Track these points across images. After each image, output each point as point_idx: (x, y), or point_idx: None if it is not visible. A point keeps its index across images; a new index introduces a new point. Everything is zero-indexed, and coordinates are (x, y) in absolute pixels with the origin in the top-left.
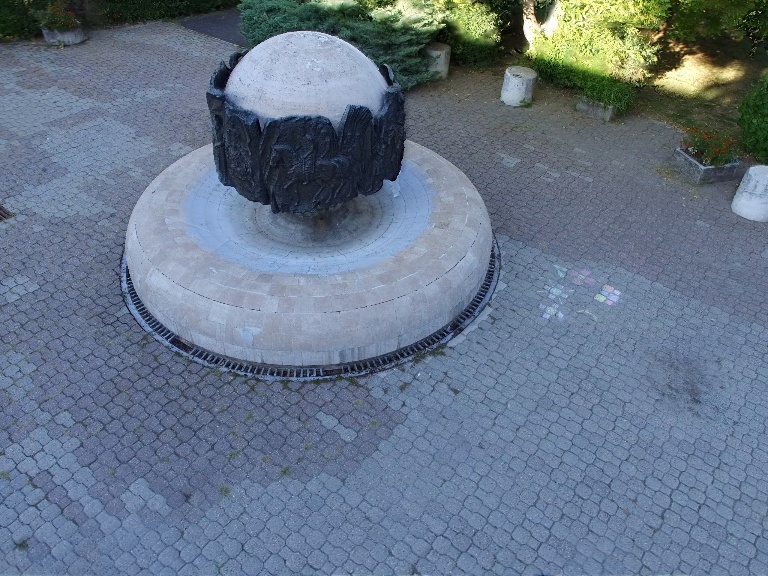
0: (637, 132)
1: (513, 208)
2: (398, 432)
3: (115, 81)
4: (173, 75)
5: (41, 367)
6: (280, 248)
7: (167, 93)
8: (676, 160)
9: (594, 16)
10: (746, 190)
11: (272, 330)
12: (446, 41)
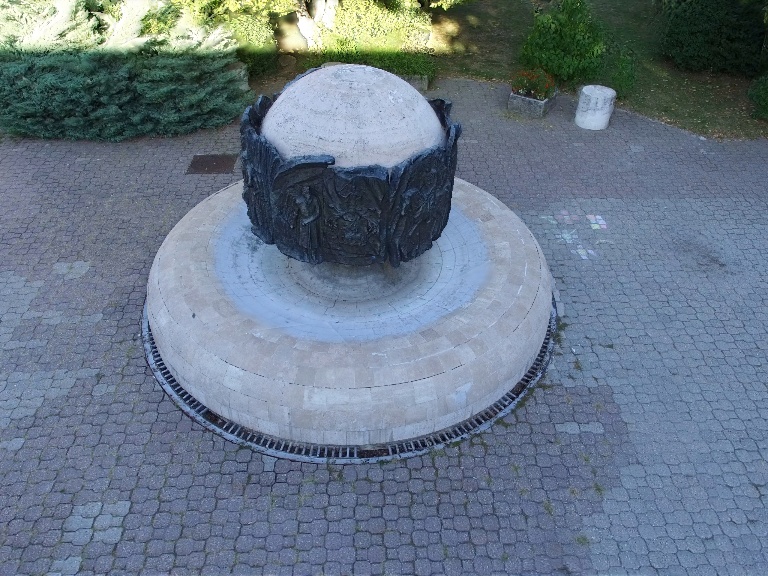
0: (456, 92)
1: None
2: (620, 401)
3: None
4: None
5: (265, 575)
6: (375, 306)
7: None
8: (513, 104)
9: None
10: (590, 108)
11: (481, 377)
12: None
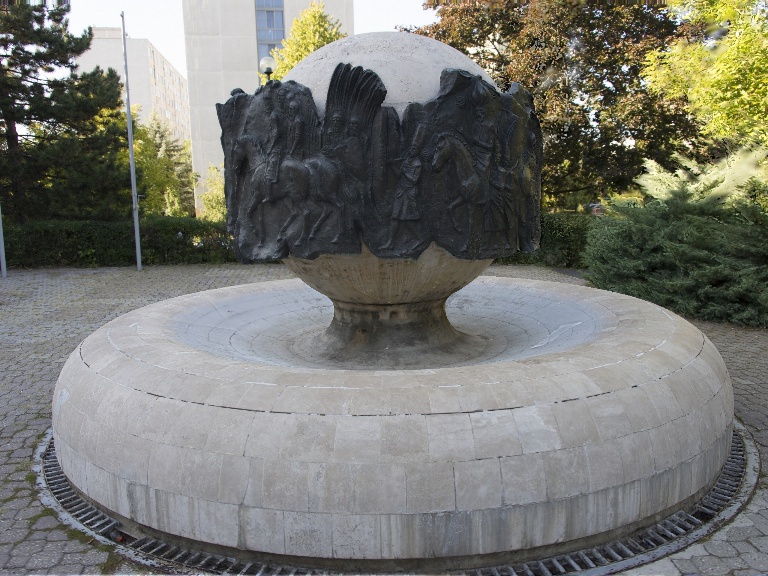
0: None
1: None
2: None
3: None
4: None
5: None
6: (277, 353)
7: None
8: None
9: None
10: None
11: (75, 400)
12: None
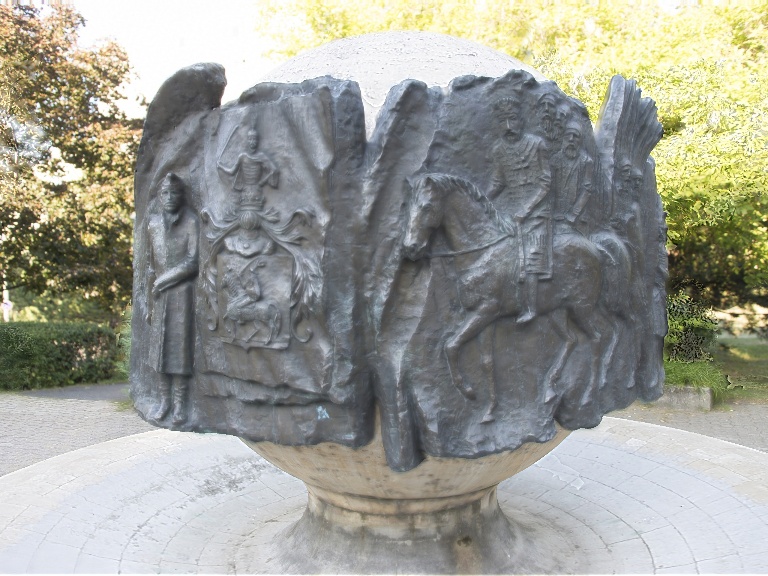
0: (764, 415)
1: None
2: None
3: None
4: None
5: None
6: None
7: None
8: None
9: (734, 195)
10: None
11: None
12: None
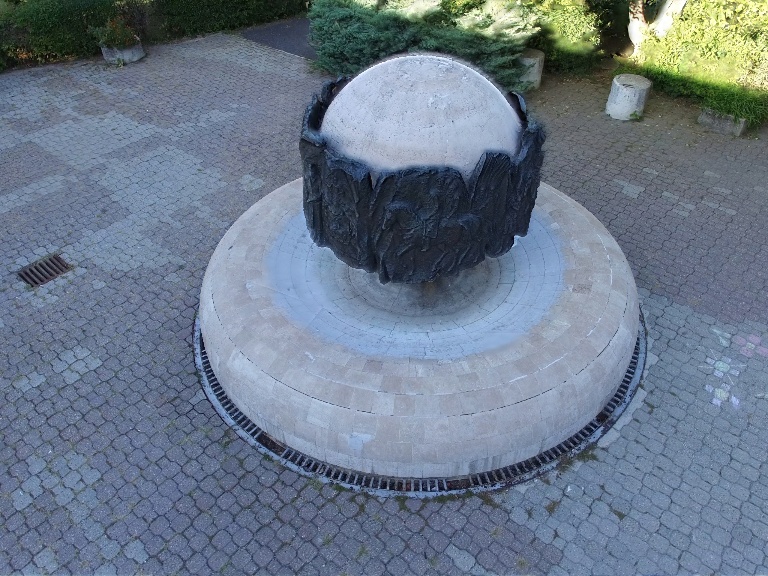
0: None
1: (647, 252)
2: None
3: (176, 103)
4: (237, 94)
5: (106, 475)
6: (383, 318)
7: (232, 115)
8: None
9: (755, 18)
10: None
11: (387, 438)
12: (538, 46)
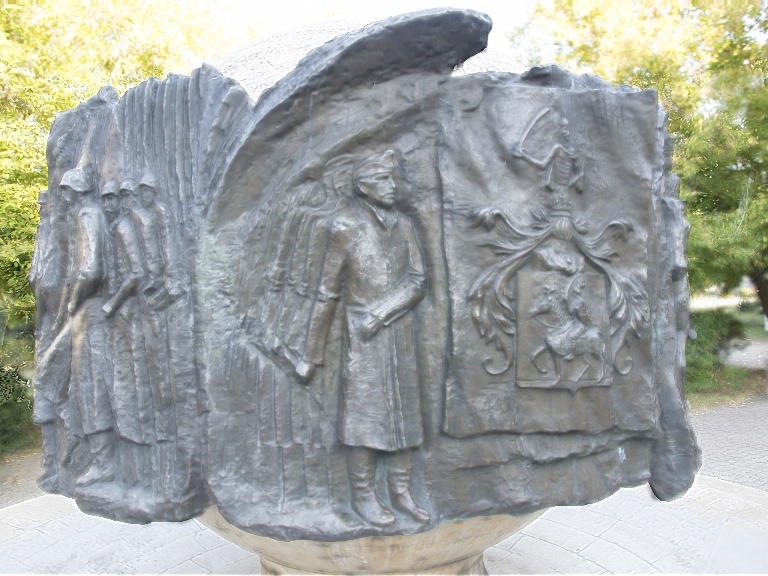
0: None
1: None
2: None
3: None
4: None
5: None
6: None
7: None
8: None
9: None
10: None
11: None
12: None
